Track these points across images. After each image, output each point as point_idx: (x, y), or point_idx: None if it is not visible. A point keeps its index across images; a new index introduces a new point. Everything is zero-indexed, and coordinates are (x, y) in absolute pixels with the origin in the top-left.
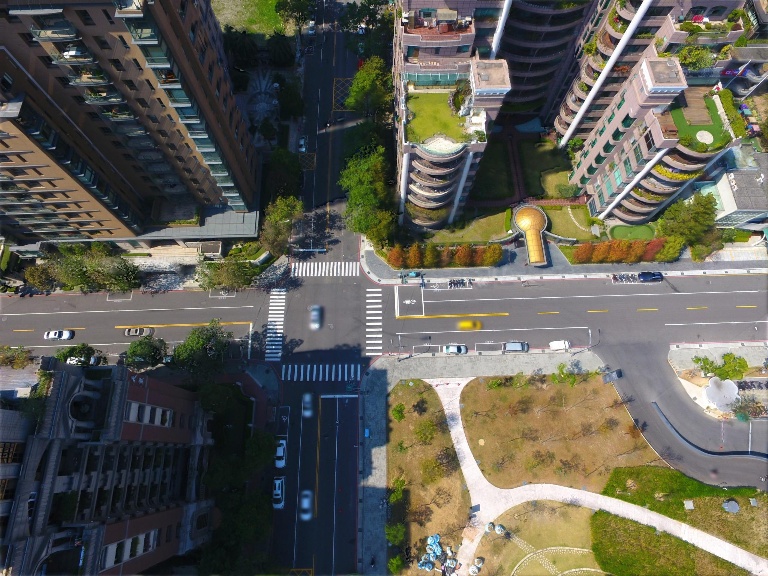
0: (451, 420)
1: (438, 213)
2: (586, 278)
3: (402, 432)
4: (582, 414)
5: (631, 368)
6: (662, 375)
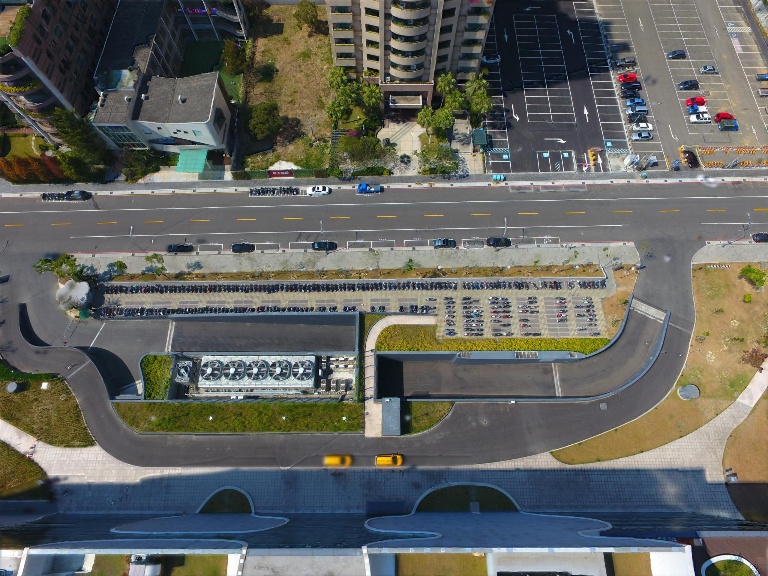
0: None
1: None
2: (20, 197)
3: None
4: None
5: (19, 274)
6: (45, 280)
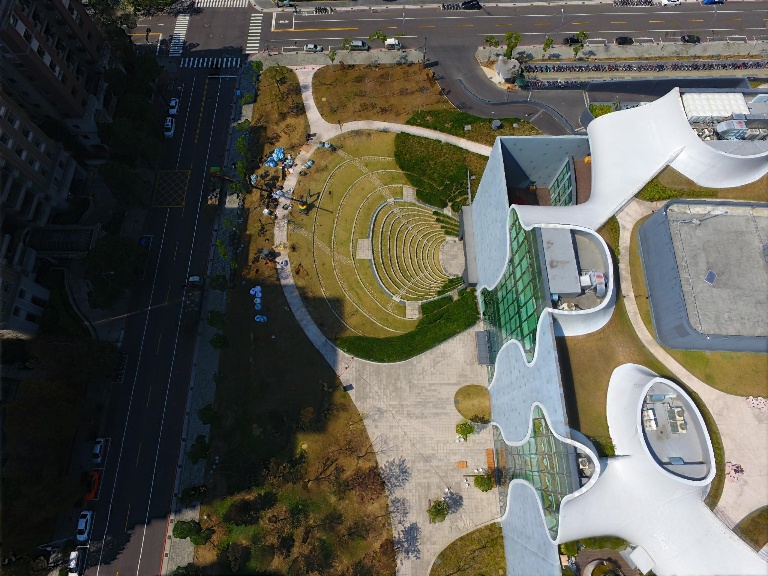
0: (304, 89)
1: None
2: (422, 7)
3: (266, 95)
4: (402, 84)
5: (446, 60)
6: (469, 64)
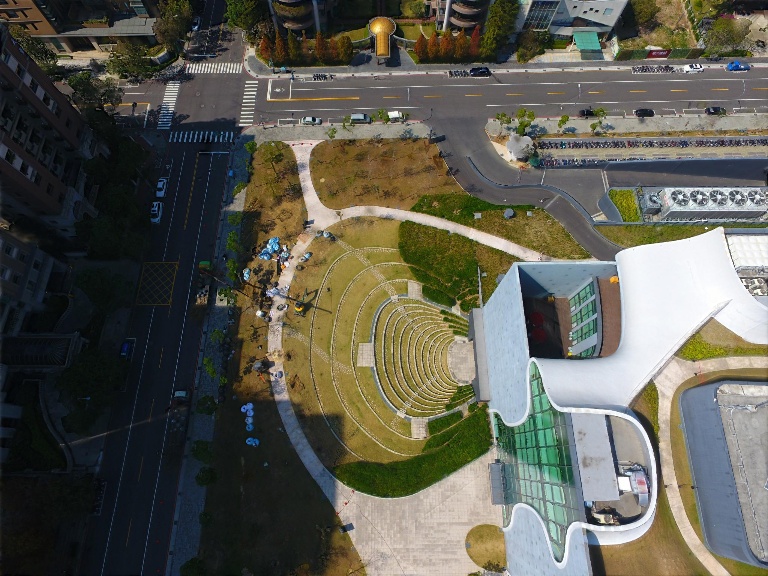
0: (301, 167)
1: (298, 9)
2: (427, 74)
3: (261, 175)
4: (407, 162)
5: (453, 134)
6: (478, 139)
